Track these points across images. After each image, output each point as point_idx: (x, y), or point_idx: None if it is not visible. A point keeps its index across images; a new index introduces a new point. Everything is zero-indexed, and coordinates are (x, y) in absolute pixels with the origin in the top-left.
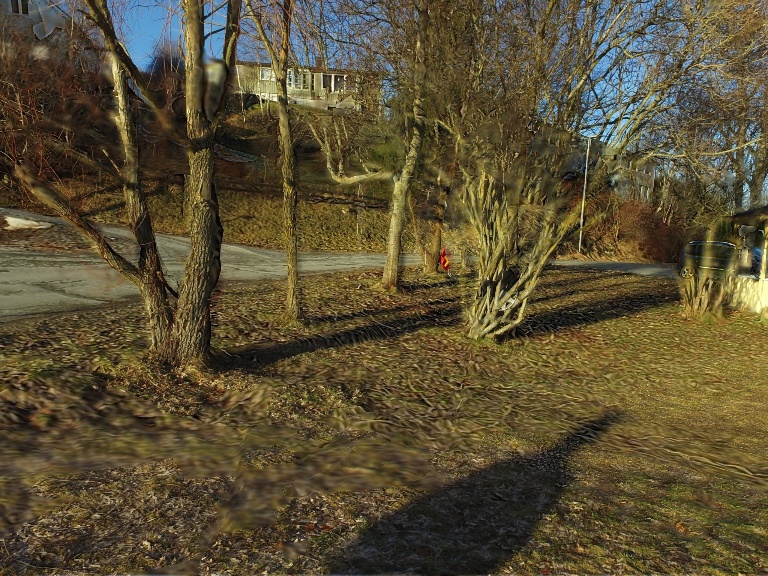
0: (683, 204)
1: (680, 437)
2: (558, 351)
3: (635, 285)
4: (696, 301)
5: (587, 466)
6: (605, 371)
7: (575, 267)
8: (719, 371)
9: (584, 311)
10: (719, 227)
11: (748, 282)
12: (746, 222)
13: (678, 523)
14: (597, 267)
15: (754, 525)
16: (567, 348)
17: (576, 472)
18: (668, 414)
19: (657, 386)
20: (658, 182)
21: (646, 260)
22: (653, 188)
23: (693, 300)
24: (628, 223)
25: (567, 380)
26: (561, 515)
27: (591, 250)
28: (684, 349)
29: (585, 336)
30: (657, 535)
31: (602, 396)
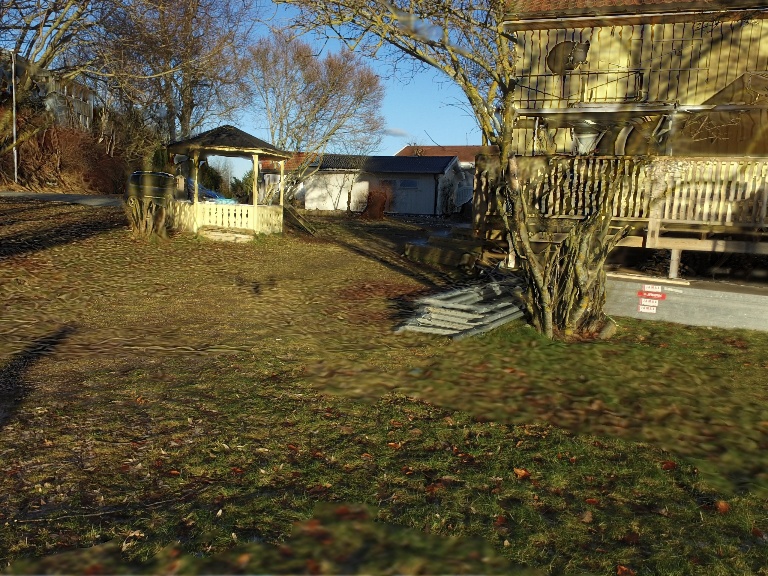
0: (124, 136)
1: (136, 335)
2: (2, 280)
3: (83, 214)
4: (143, 224)
5: (48, 376)
6: (59, 293)
7: (13, 198)
8: (166, 280)
9: (29, 239)
10: (159, 159)
11: (185, 206)
12: (179, 151)
13: (139, 398)
14: (39, 198)
15: (198, 383)
16: (13, 276)
17: (36, 383)
18: (124, 320)
19: (112, 299)
20: (97, 112)
21: (93, 192)
22: (92, 118)
23: (140, 223)
24: (69, 152)
25: (16, 306)
26: (24, 422)
27: (30, 181)
28: (135, 266)
29: (33, 263)
30: (121, 412)
31: (58, 315)
